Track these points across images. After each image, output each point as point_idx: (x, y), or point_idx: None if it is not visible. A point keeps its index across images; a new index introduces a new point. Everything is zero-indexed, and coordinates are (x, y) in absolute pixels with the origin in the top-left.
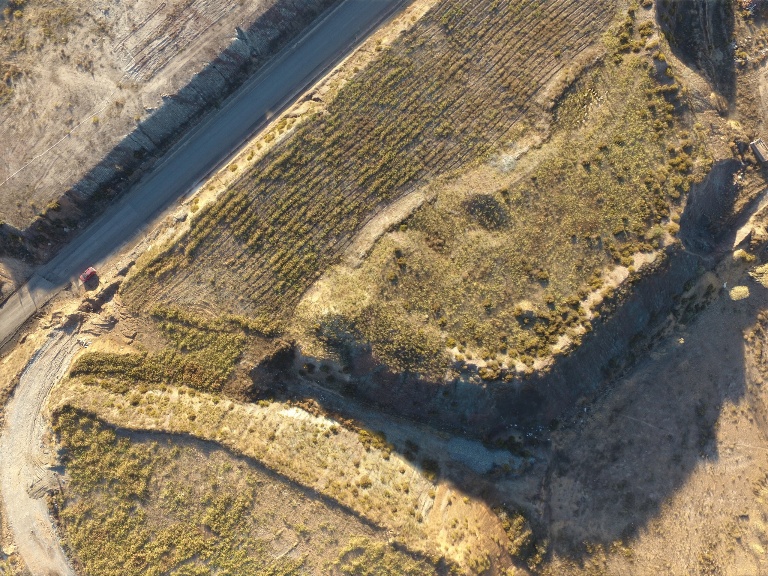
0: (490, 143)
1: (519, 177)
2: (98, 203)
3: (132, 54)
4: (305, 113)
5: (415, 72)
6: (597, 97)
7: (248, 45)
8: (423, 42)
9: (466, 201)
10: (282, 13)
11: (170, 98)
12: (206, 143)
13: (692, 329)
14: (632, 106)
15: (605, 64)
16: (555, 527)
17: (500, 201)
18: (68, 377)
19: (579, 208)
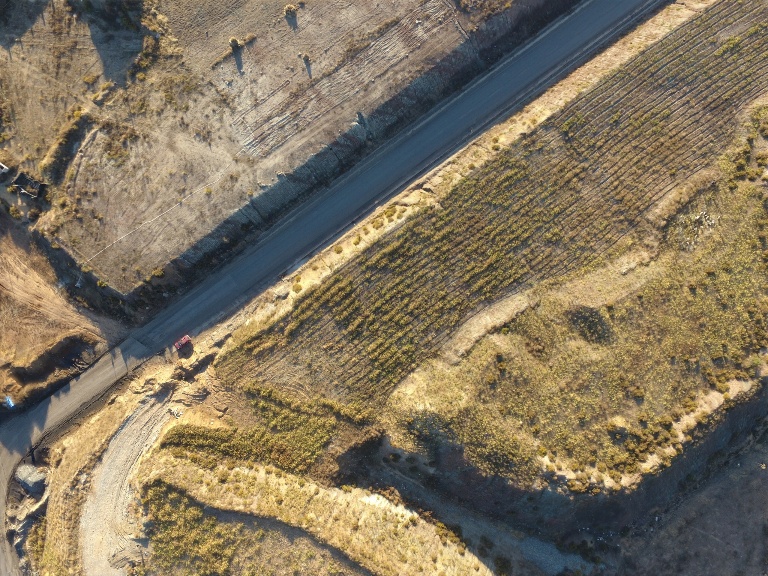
0: (597, 253)
1: (625, 294)
2: (199, 271)
3: (251, 129)
4: (416, 204)
5: (531, 175)
6: (709, 221)
7: (366, 129)
8: (542, 146)
9: (570, 311)
10: (403, 101)
11: (285, 176)
12: (312, 221)
13: (767, 449)
14: (743, 235)
15: (719, 188)
16: None
17: (605, 316)
18: (158, 448)
19: (681, 330)
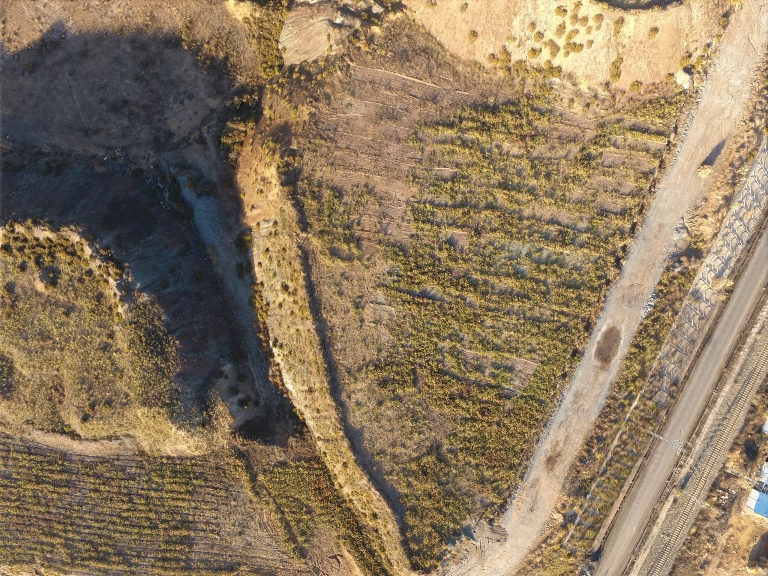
0: None
1: None
2: None
3: None
4: (54, 575)
5: None
6: None
7: None
8: None
9: (5, 399)
10: None
11: None
12: None
13: None
14: None
15: None
16: (214, 105)
17: None
18: None
19: None
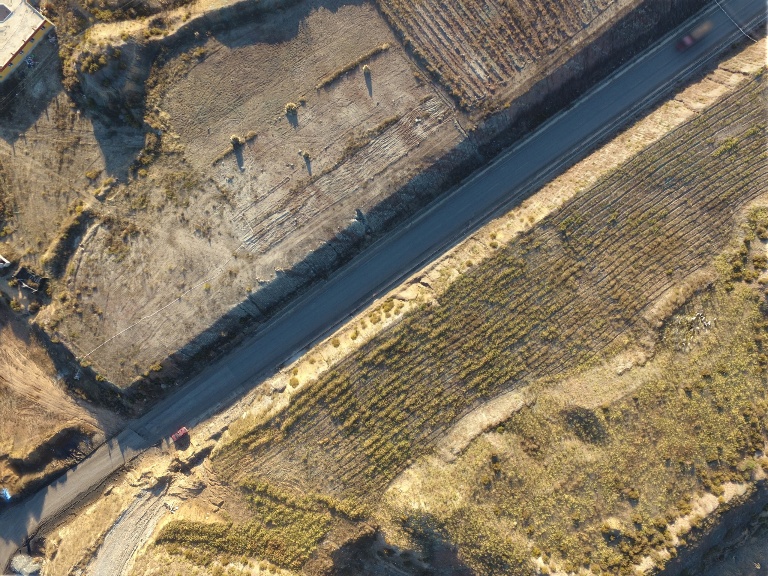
0: (593, 352)
1: (621, 395)
2: (197, 363)
3: (251, 225)
4: (414, 299)
5: (528, 274)
6: (705, 322)
7: (364, 224)
8: (539, 245)
9: (565, 410)
10: (402, 197)
11: (284, 272)
12: (310, 313)
13: (763, 542)
14: (739, 337)
15: (716, 290)
16: None
17: (600, 417)
18: (153, 544)
19: (676, 433)
